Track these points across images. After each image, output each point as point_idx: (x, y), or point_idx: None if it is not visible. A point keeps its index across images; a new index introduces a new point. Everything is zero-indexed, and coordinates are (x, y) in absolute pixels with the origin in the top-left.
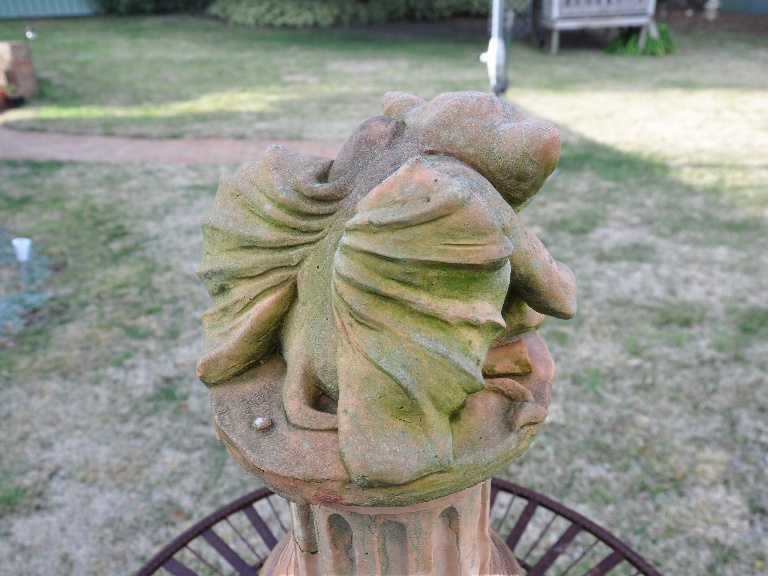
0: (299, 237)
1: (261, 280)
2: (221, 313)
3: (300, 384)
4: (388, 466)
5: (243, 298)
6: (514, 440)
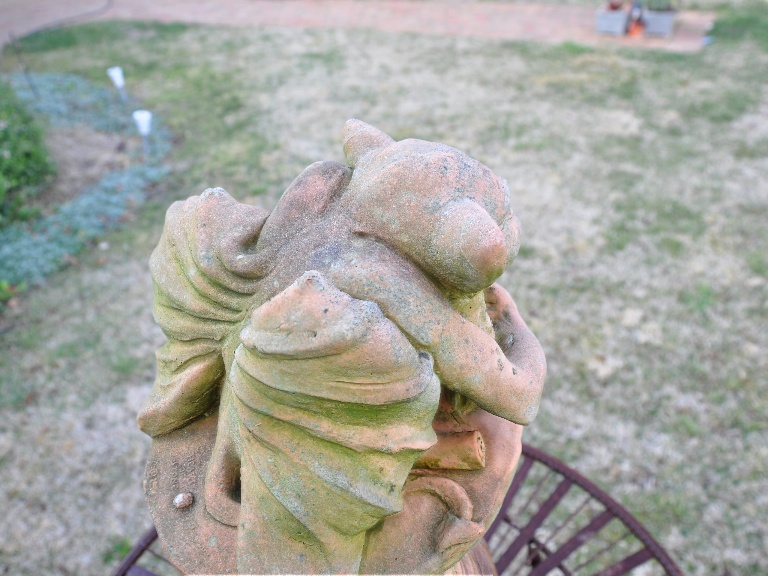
0: (220, 313)
1: (190, 346)
2: (164, 363)
3: (222, 465)
4: None
5: (175, 360)
6: (435, 563)
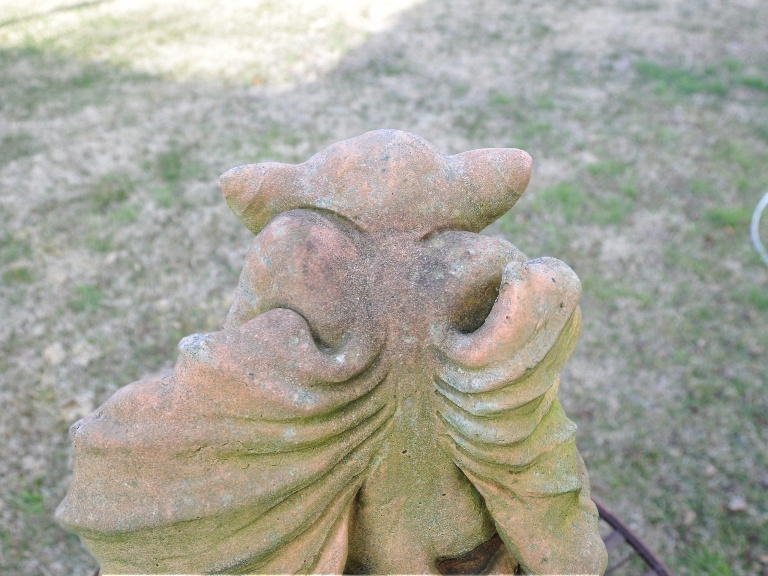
0: (355, 437)
1: (319, 524)
2: None
3: None
4: (600, 564)
5: (303, 565)
6: None
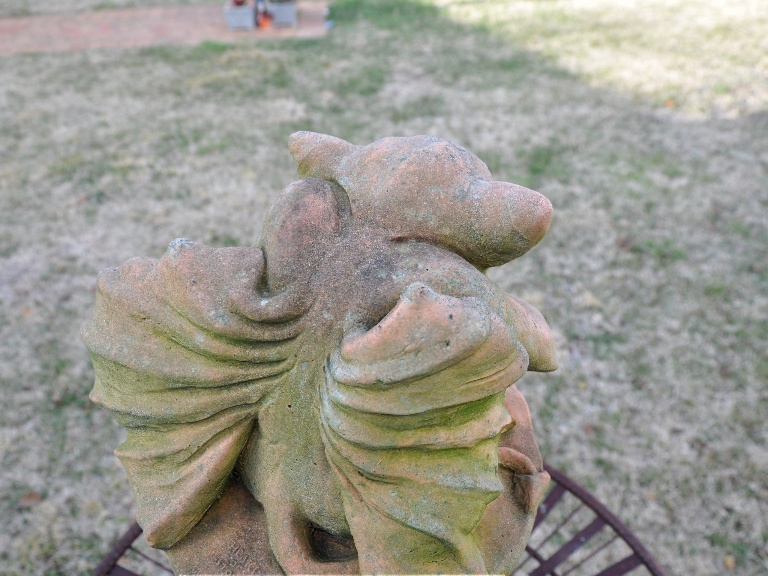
0: (253, 371)
1: (209, 424)
2: (155, 460)
3: (292, 535)
4: None
5: (188, 447)
6: None
